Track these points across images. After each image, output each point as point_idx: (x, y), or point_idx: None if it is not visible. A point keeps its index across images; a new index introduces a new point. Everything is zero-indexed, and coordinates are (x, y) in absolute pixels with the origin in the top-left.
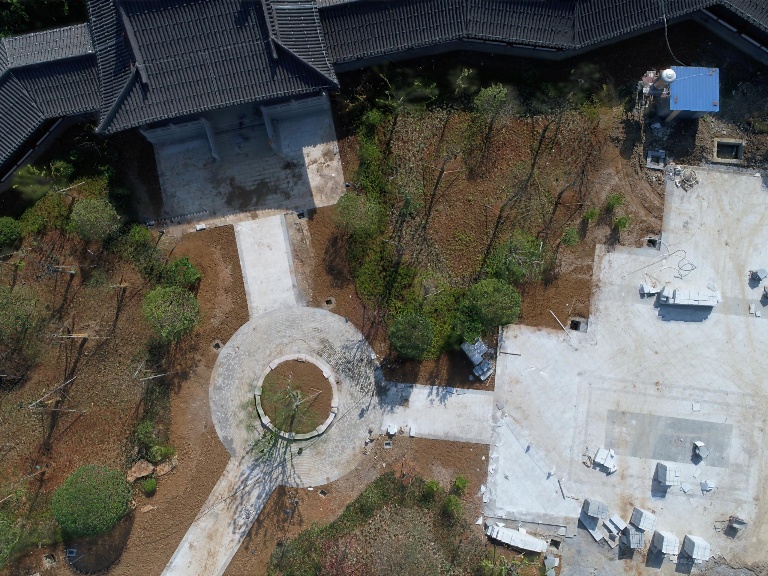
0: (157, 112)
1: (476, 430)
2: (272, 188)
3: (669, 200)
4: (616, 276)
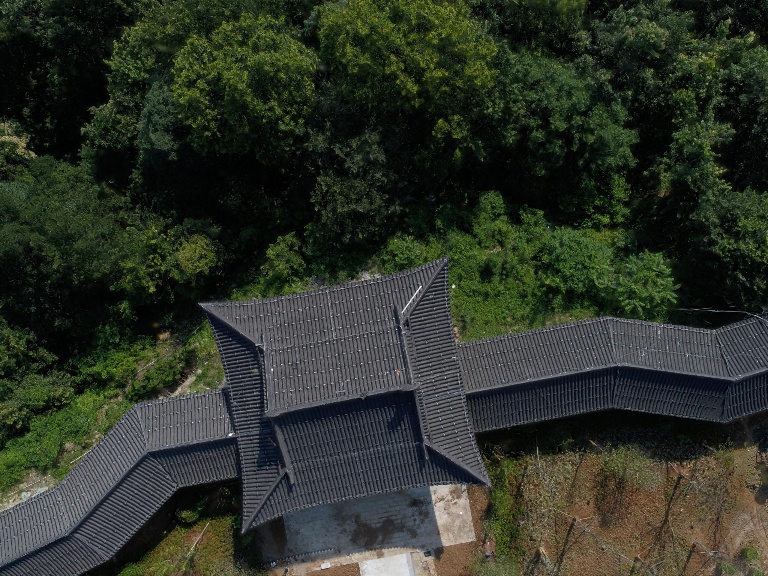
0: (301, 502)
1: None
2: (398, 526)
3: None
4: None
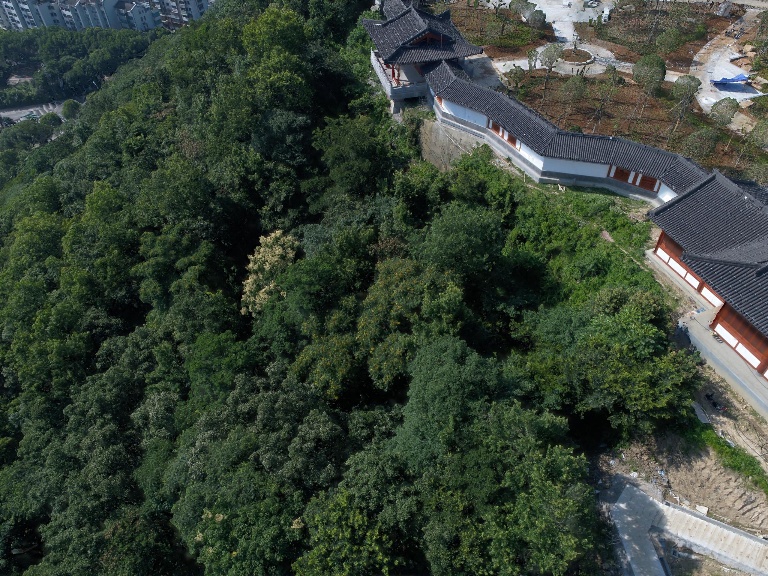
0: None
1: None
2: None
3: None
4: None
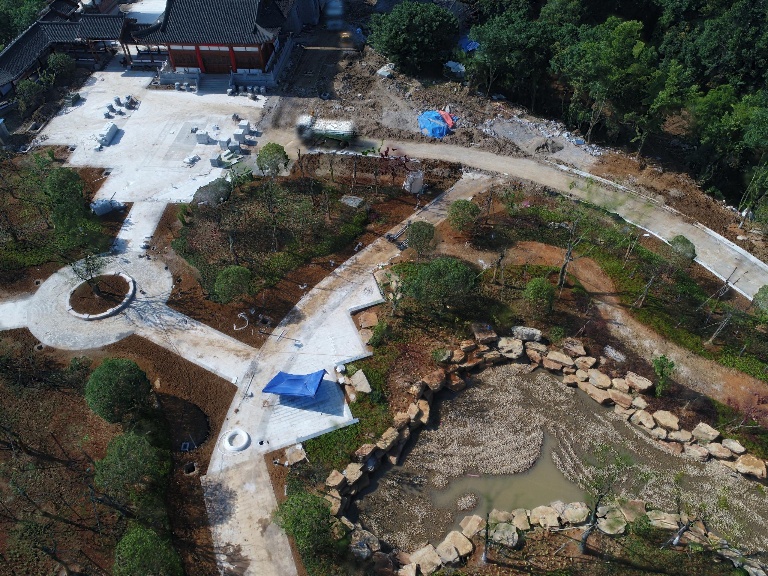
0: None
1: (157, 209)
2: None
3: (50, 143)
4: (85, 160)
